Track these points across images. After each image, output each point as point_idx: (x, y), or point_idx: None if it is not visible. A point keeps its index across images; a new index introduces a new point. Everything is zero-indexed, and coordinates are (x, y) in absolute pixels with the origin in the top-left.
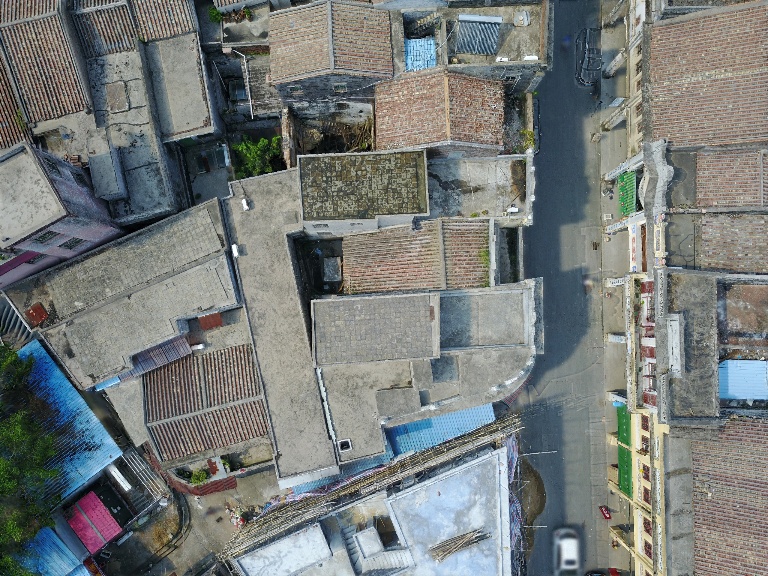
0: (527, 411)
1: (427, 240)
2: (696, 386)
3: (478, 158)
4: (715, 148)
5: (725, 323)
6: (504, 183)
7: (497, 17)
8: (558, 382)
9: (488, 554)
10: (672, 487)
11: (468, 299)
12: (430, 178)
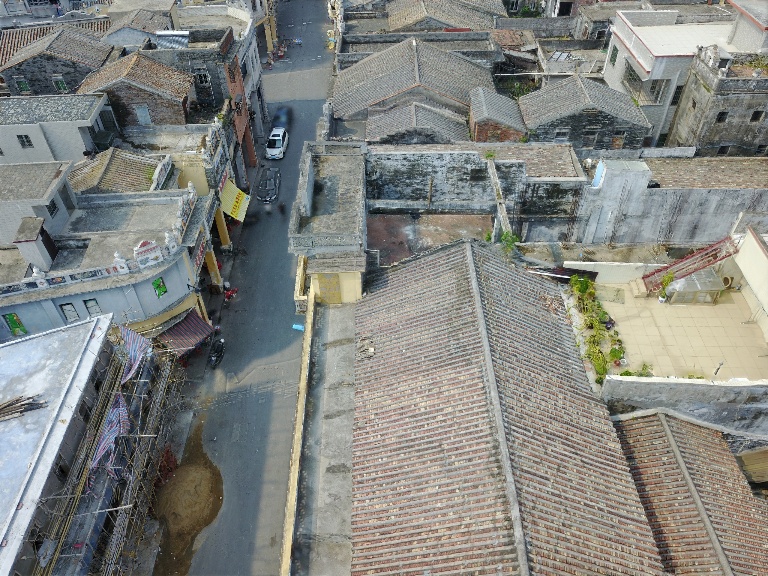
0: (220, 399)
1: (96, 163)
2: (337, 224)
3: (170, 128)
4: (376, 108)
5: (415, 241)
6: (193, 145)
7: (185, 31)
8: (265, 369)
9: (31, 429)
10: (329, 358)
11: (126, 208)
12: (125, 143)
